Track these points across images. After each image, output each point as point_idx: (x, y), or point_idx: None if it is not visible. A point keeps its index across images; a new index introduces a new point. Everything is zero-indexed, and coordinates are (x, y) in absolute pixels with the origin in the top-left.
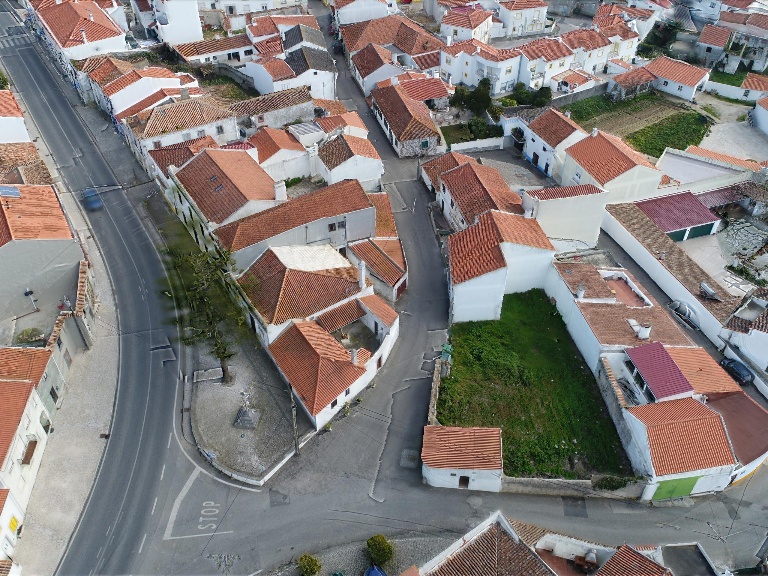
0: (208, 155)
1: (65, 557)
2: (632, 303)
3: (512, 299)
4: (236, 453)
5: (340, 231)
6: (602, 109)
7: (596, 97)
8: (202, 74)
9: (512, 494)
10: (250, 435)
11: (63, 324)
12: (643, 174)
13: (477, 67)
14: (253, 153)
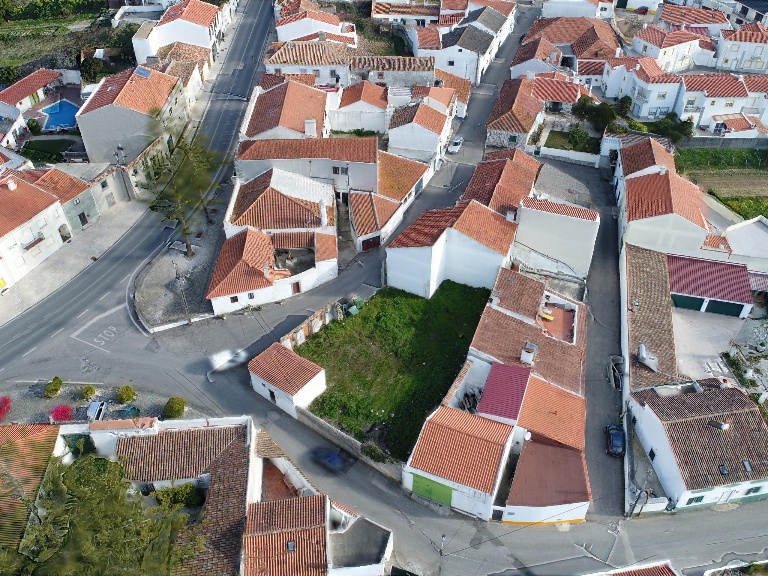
0: (287, 85)
1: (15, 319)
2: (560, 335)
3: (457, 288)
4: (152, 304)
5: (344, 176)
6: (750, 163)
7: (755, 150)
8: (379, 31)
9: (305, 426)
10: (171, 297)
11: (114, 173)
12: (680, 225)
13: (633, 85)
14: (334, 97)
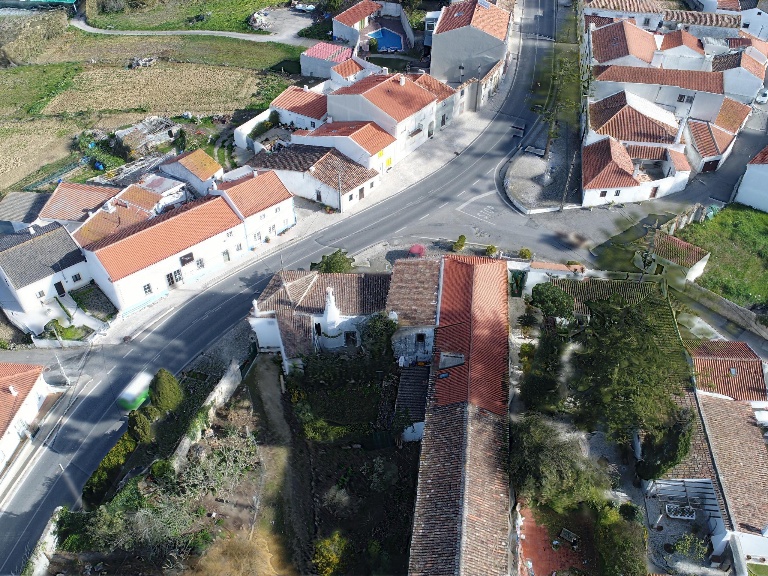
0: (623, 24)
1: (403, 191)
2: None
3: None
4: (524, 192)
5: (687, 105)
6: None
7: None
8: None
9: (690, 298)
10: (538, 188)
11: (470, 85)
12: None
13: None
14: (659, 39)
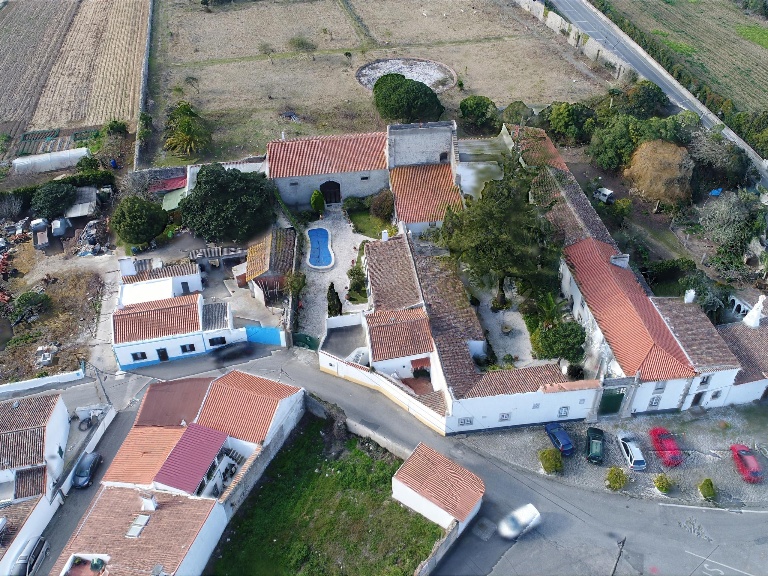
0: None
1: None
2: None
3: None
4: None
5: None
6: None
7: None
8: None
9: None
10: None
11: None
12: None
13: None
14: None
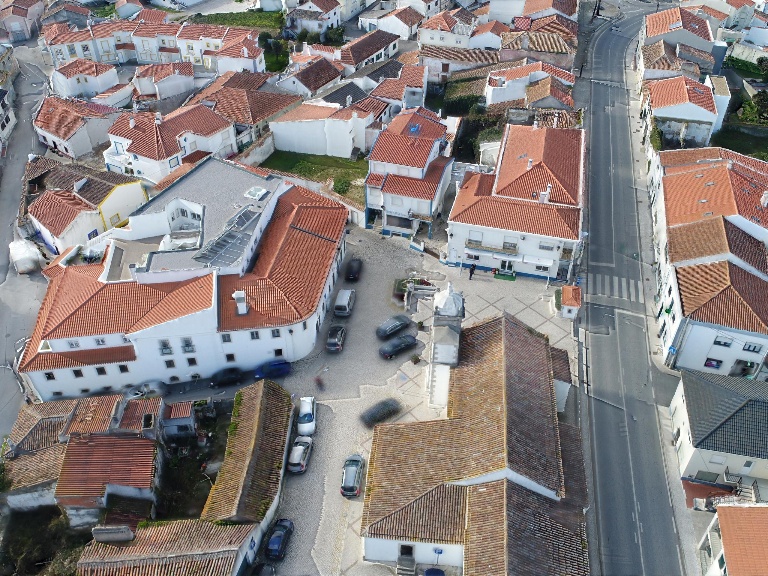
0: (553, 6)
1: None
2: None
3: None
4: (609, 6)
5: None
6: None
7: None
8: None
9: None
10: None
11: None
12: None
13: None
14: None
